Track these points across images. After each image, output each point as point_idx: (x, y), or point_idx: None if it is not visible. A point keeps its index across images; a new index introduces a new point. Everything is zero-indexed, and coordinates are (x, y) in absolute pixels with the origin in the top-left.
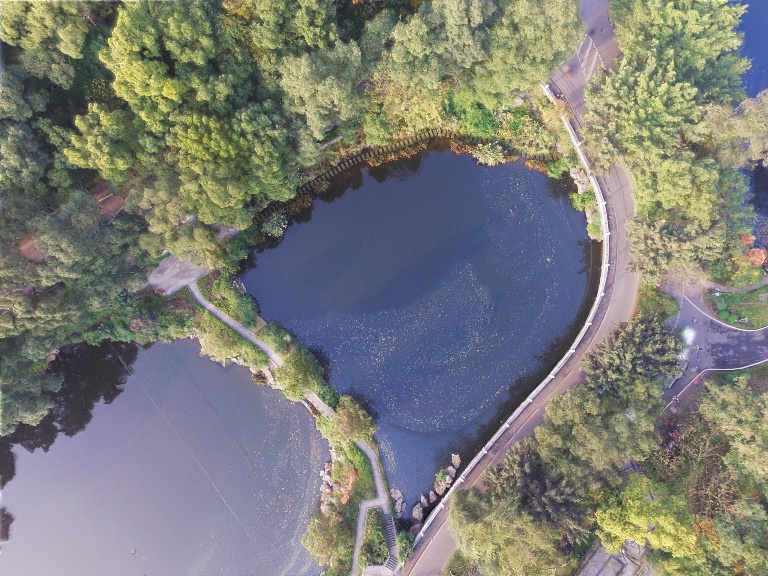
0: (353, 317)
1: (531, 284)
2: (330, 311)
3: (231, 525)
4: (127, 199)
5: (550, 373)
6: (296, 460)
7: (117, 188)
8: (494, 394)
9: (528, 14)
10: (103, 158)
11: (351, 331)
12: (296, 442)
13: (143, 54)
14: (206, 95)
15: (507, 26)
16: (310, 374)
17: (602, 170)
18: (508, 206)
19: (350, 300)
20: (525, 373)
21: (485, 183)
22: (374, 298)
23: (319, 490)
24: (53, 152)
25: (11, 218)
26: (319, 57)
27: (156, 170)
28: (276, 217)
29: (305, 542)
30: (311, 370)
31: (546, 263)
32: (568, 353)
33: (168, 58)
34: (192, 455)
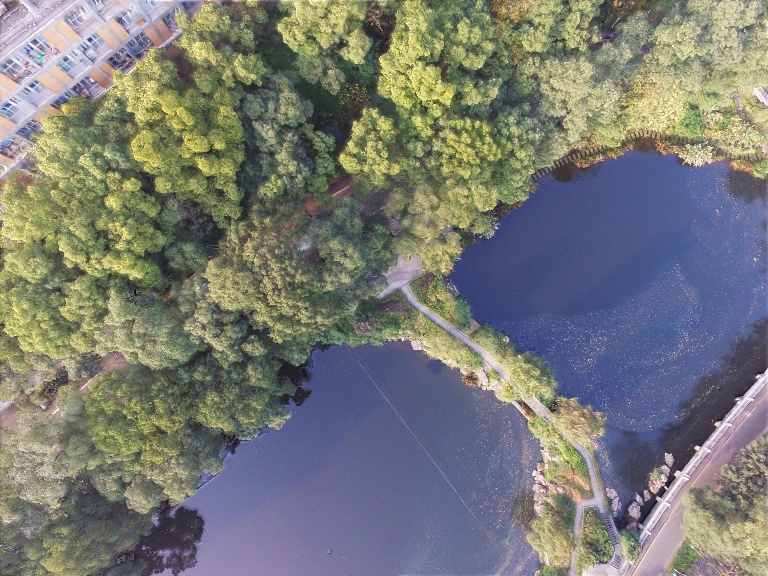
0: (564, 318)
1: (739, 284)
2: (541, 312)
3: (446, 525)
4: (390, 204)
5: (766, 372)
6: (508, 460)
7: (368, 192)
8: (705, 393)
9: None
10: (383, 163)
11: (563, 332)
12: (508, 442)
13: None
14: (480, 99)
15: (767, 28)
16: None
17: None
18: (714, 206)
19: (561, 301)
20: (735, 372)
21: (691, 183)
22: (584, 299)
23: (532, 490)
24: (315, 157)
25: (293, 224)
26: None
27: (413, 174)
28: (491, 219)
29: (535, 541)
30: (550, 371)
31: (753, 263)
32: None
33: (441, 63)
34: (430, 457)
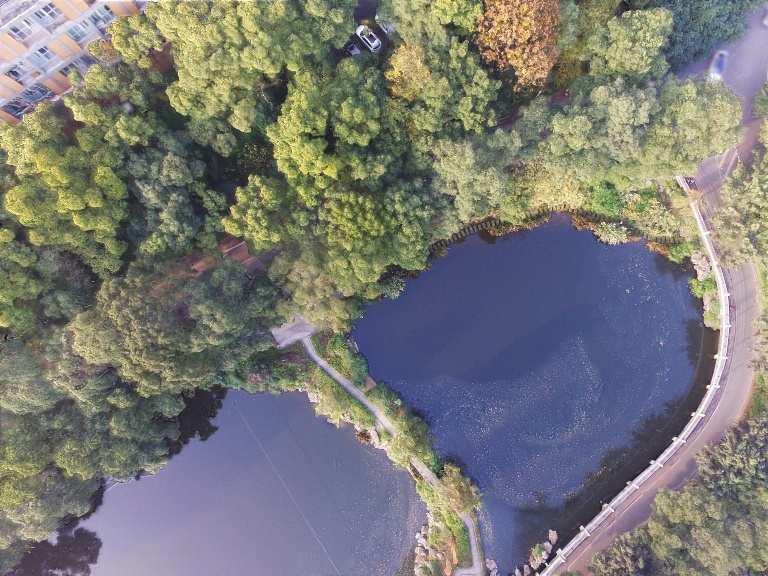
0: (462, 385)
1: (642, 367)
2: (439, 377)
3: None
4: (273, 268)
5: (657, 460)
6: (393, 520)
7: (259, 252)
8: (596, 474)
9: (693, 117)
10: (261, 232)
11: (459, 399)
12: (395, 502)
13: (310, 133)
14: (365, 176)
15: (667, 125)
16: (429, 448)
17: (732, 264)
18: (625, 286)
19: (460, 367)
20: (629, 456)
21: (604, 261)
22: (484, 367)
23: (414, 552)
24: (204, 215)
25: (167, 283)
26: (476, 143)
27: (301, 239)
28: (395, 281)
29: None
30: (429, 443)
31: (659, 347)
32: (677, 442)
33: (330, 135)
34: None
